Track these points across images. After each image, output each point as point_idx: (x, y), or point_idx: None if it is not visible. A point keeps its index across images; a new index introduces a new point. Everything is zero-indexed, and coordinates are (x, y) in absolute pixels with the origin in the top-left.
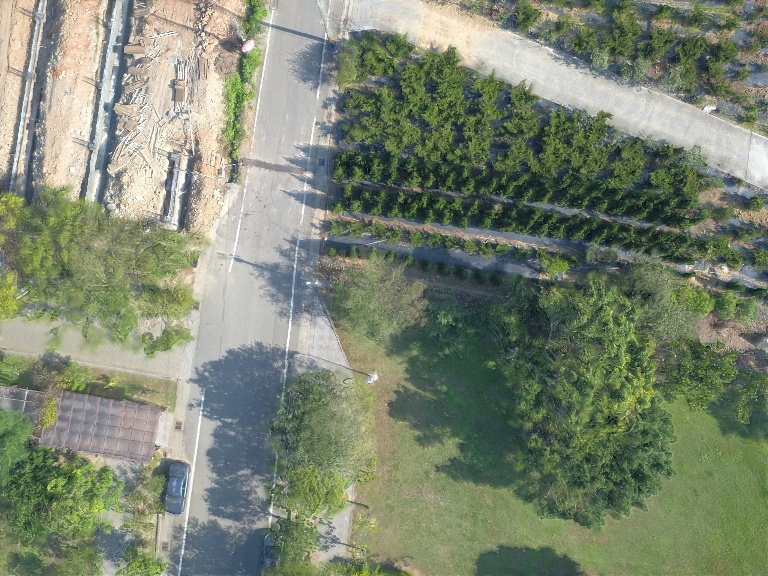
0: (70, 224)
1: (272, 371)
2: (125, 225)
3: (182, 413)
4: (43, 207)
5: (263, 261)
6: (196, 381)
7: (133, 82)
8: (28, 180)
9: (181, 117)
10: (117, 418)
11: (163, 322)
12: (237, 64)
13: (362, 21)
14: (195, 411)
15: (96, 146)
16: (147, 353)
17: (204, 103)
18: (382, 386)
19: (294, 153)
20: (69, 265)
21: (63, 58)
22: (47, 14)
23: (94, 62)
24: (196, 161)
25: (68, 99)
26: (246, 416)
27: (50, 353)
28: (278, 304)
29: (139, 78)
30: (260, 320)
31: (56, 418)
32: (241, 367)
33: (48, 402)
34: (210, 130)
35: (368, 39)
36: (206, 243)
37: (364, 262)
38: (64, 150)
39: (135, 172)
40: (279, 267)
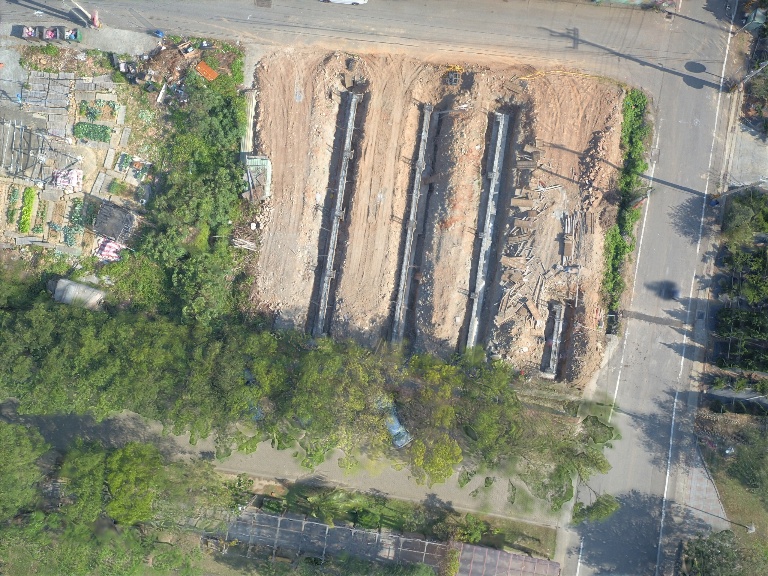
0: (511, 397)
1: (649, 520)
2: (507, 374)
3: (561, 560)
4: (427, 356)
5: (642, 412)
6: (575, 529)
7: (519, 234)
8: (405, 325)
9: (570, 272)
10: (516, 572)
11: (591, 491)
12: (616, 216)
13: (743, 176)
14: (574, 559)
15: (477, 295)
16: (575, 521)
17: (591, 257)
18: (758, 538)
19: (674, 306)
20: (518, 441)
21: (453, 211)
22: (425, 161)
23: (476, 212)
24: (578, 313)
25: (455, 250)
26: (623, 564)
27: (431, 499)
28: (656, 455)
29: (526, 231)
30: (638, 470)
31: (457, 571)
32: (619, 516)
33: (450, 555)
34: (594, 283)
35: (754, 197)
36: (586, 393)
37: (742, 415)
38: (452, 301)
39: (522, 324)
40: (657, 418)
